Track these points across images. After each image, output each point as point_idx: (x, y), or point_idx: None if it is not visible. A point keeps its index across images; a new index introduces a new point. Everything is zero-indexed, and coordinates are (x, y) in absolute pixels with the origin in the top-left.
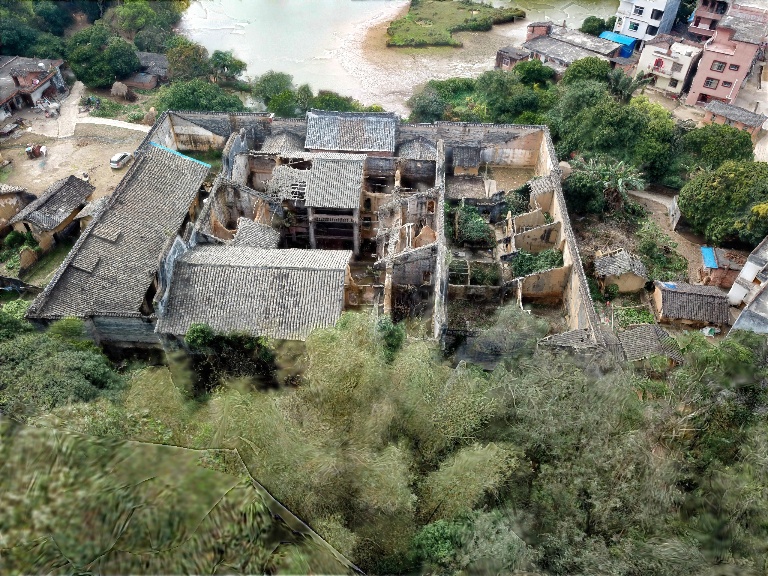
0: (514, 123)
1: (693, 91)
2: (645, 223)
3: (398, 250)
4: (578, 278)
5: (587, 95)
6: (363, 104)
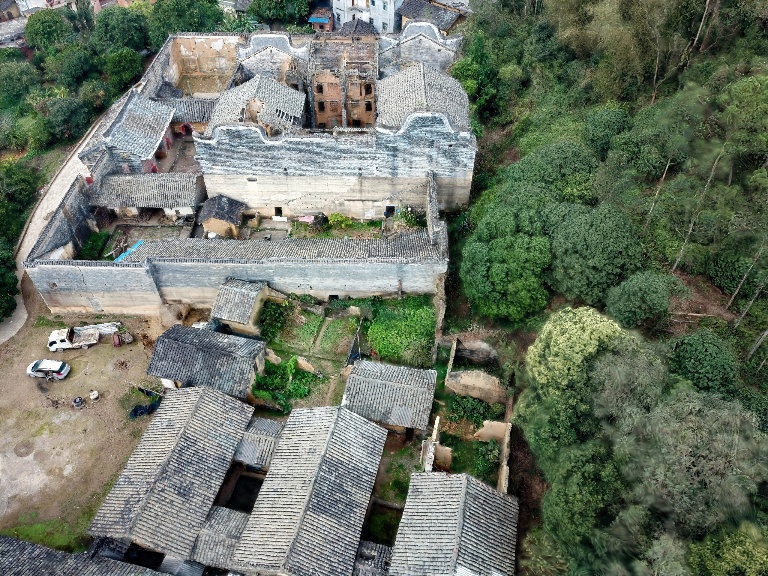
0: (96, 81)
1: (94, 0)
2: (289, 29)
3: (359, 78)
4: (368, 37)
5: (125, 16)
6: (4, 164)
